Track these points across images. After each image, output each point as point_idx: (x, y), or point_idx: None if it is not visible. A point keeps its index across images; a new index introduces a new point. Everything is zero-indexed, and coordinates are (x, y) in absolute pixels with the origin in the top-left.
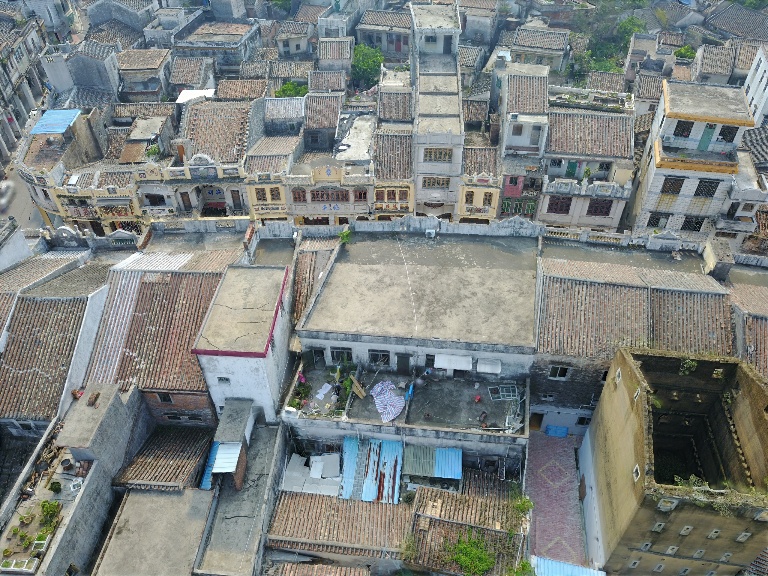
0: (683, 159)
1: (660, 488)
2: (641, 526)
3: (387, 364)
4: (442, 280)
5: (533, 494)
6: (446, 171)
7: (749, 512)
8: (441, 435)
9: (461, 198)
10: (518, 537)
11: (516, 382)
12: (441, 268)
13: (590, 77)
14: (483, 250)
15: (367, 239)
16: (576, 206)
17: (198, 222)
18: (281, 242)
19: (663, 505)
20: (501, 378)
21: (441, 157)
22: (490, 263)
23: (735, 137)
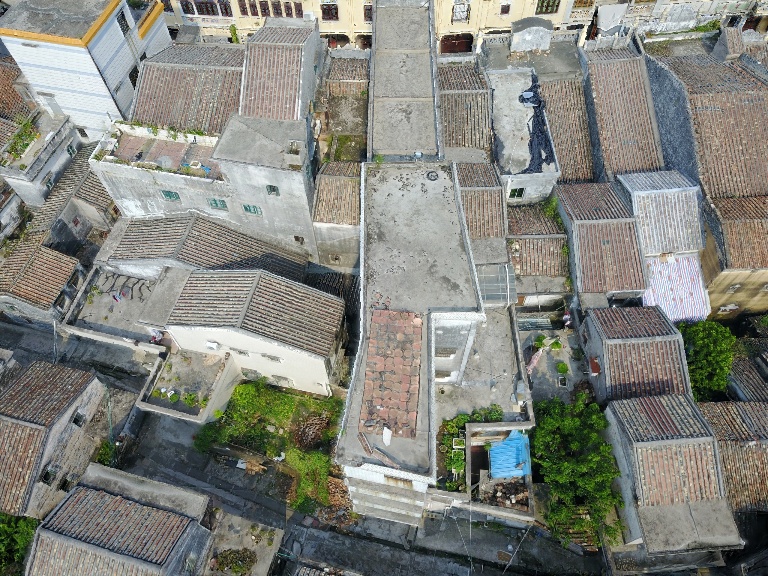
0: None
1: None
2: None
3: None
4: None
5: None
6: None
7: None
8: None
9: None
10: None
11: None
12: None
13: (63, 411)
14: None
15: None
16: None
17: None
18: None
19: None
20: None
21: None
22: None
23: None
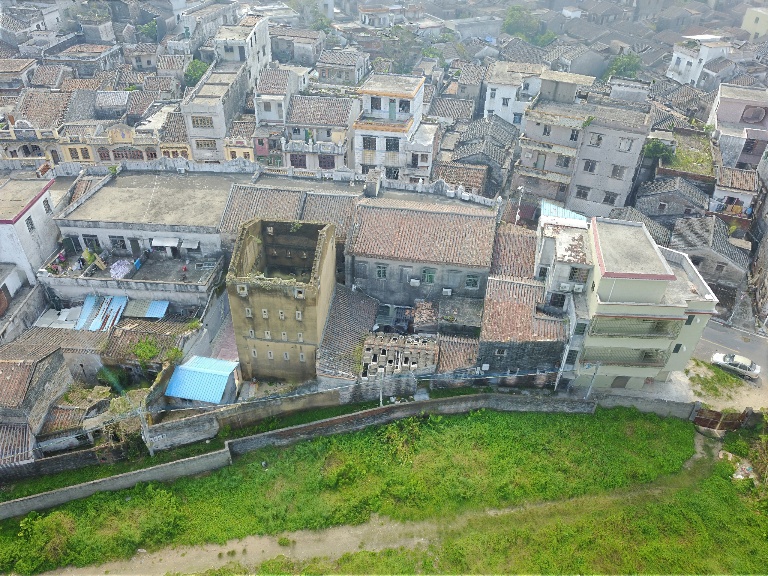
0: (369, 122)
1: (235, 278)
2: (239, 313)
3: (125, 248)
4: (176, 196)
5: (225, 337)
6: (211, 135)
7: (289, 291)
8: (148, 287)
9: (227, 157)
10: (178, 337)
11: (216, 260)
12: (179, 190)
13: None
14: (216, 180)
15: (134, 174)
16: (310, 161)
17: (7, 161)
18: (72, 178)
19: (242, 292)
20: (205, 257)
21: (205, 124)
22: (216, 187)
23: (410, 109)
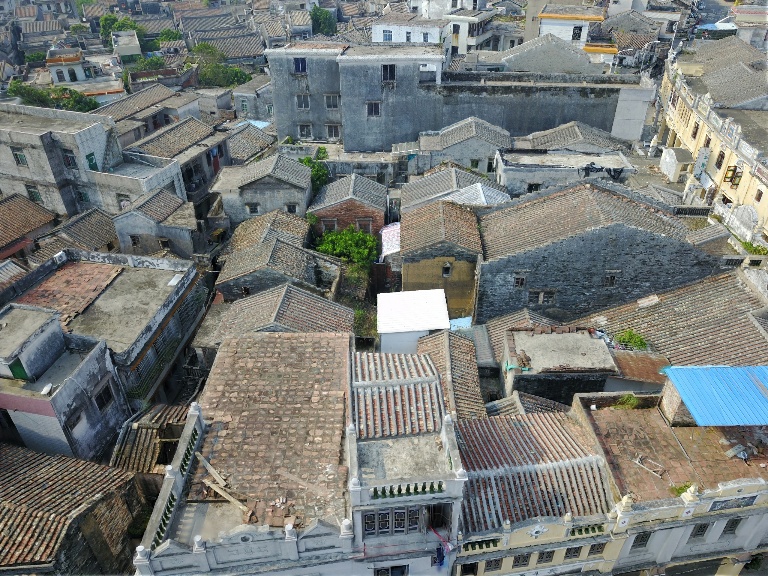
0: None
1: None
2: None
3: None
4: None
5: None
6: None
7: None
8: None
9: None
10: None
11: None
12: None
13: None
14: None
15: None
16: None
17: None
18: None
19: None
20: None
21: None
22: (747, 121)
23: None
